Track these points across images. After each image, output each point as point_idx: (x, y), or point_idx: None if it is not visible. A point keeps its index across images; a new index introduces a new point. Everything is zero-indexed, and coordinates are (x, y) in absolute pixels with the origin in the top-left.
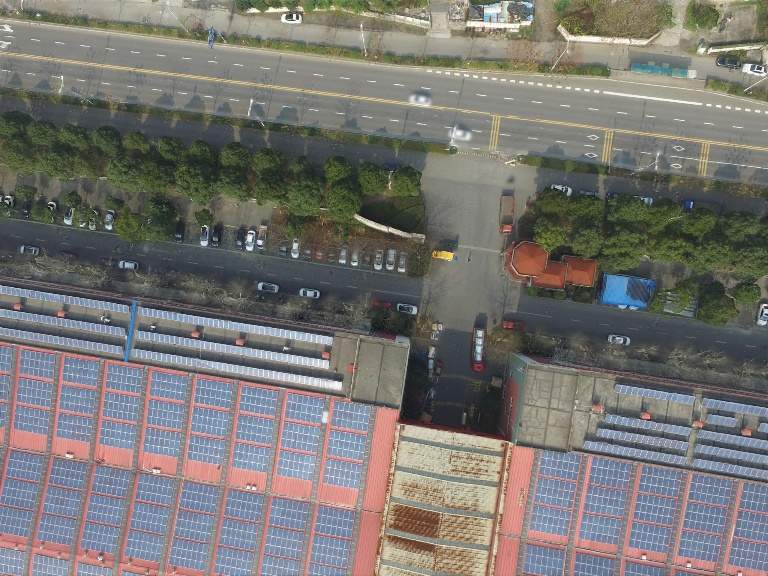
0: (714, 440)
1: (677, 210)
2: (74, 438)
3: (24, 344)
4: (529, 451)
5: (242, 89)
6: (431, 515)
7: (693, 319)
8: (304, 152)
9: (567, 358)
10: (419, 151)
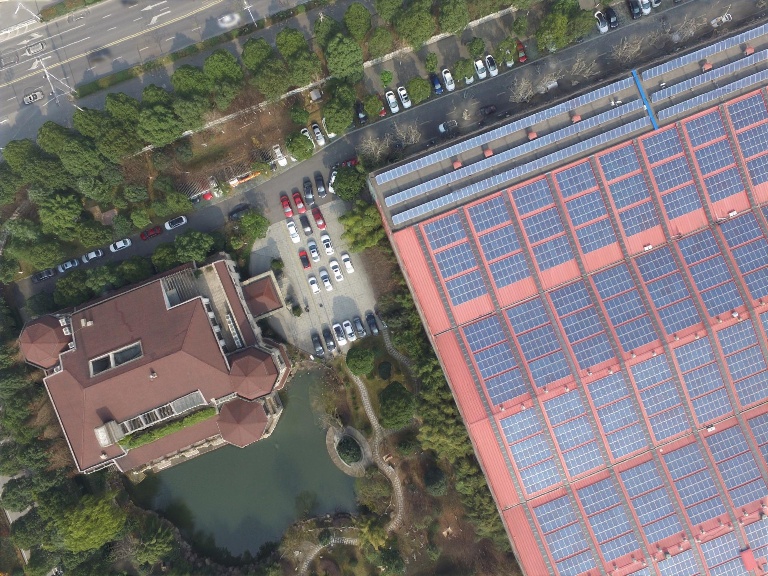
0: None
1: None
2: (644, 229)
3: (555, 168)
4: None
5: None
6: None
7: None
8: None
9: None
10: None
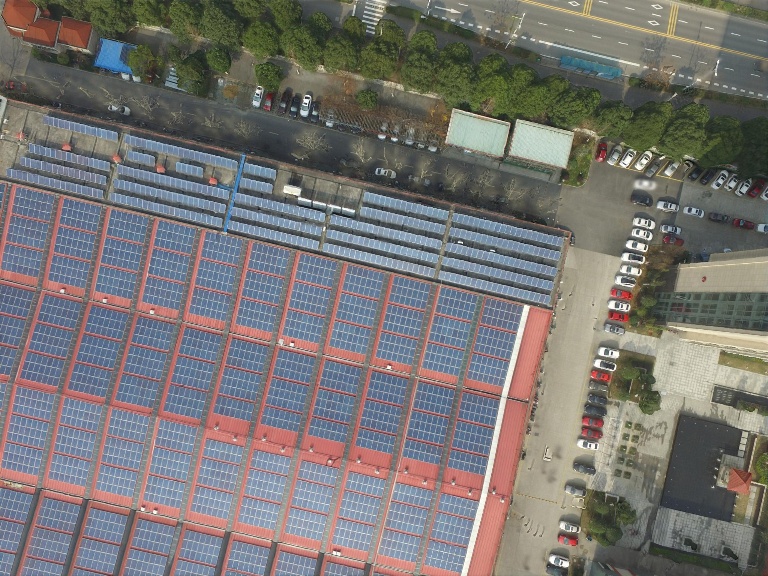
0: (135, 178)
1: None
2: None
3: None
4: None
5: None
6: None
7: (194, 96)
8: None
9: None
10: None
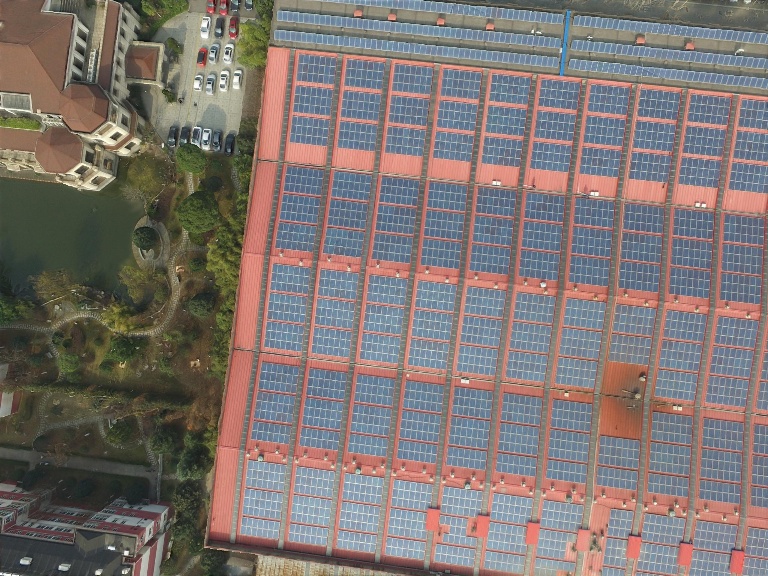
0: None
1: None
2: (501, 163)
3: (446, 63)
4: None
5: None
6: None
7: None
8: None
9: None
10: None
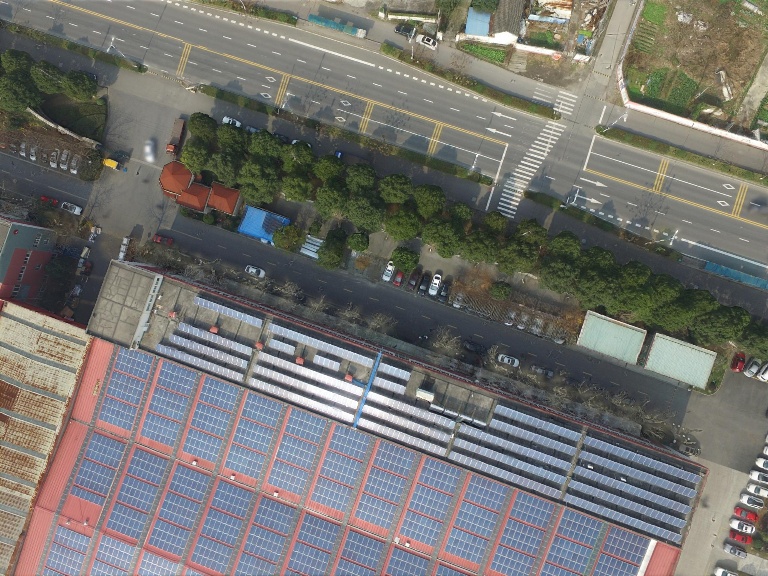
0: (274, 364)
1: (295, 149)
2: None
3: None
4: (109, 345)
5: None
6: (11, 389)
7: None
8: (11, 47)
9: (195, 277)
10: (112, 64)
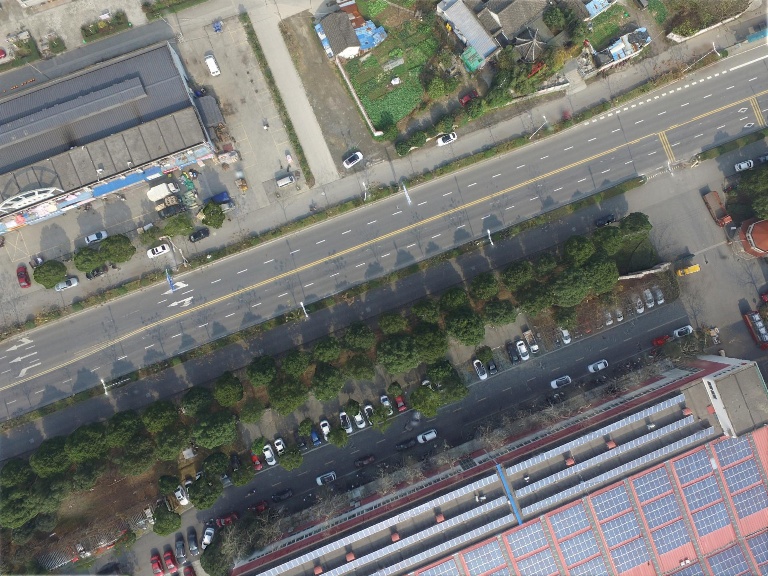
0: None
1: None
2: None
3: (418, 568)
4: None
5: (437, 223)
6: None
7: None
8: (522, 248)
9: None
10: (618, 195)
